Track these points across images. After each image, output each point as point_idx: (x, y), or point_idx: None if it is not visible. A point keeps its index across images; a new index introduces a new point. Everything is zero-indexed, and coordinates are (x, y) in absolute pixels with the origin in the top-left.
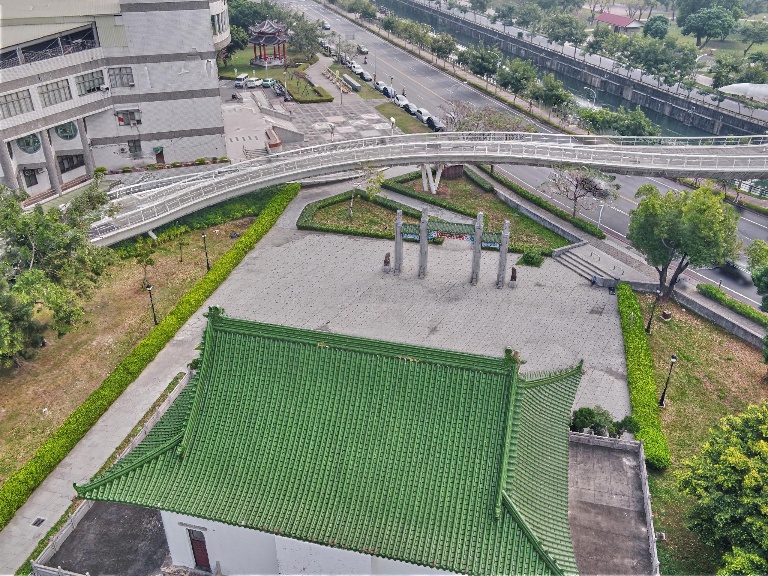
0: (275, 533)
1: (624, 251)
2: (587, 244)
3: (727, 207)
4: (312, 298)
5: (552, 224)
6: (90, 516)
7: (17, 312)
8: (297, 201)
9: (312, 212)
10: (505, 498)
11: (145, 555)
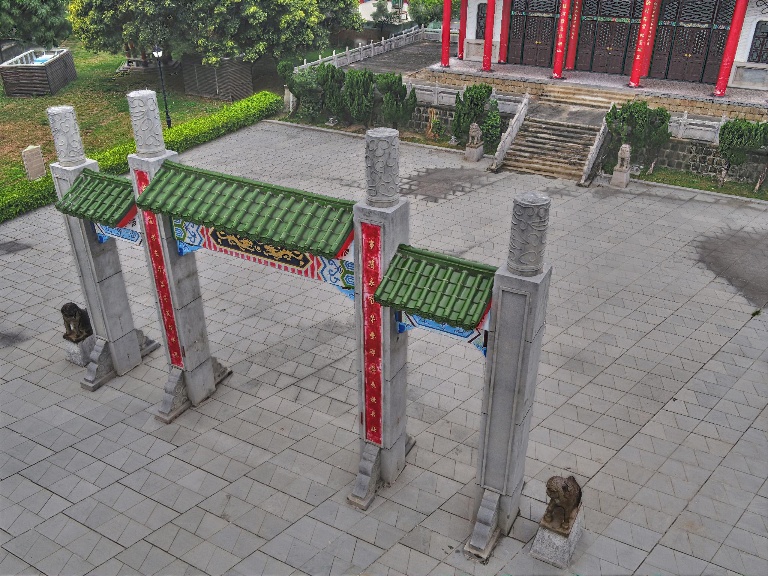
0: None
1: None
2: None
3: None
4: None
5: None
6: None
7: None
8: None
9: None
10: None
11: None
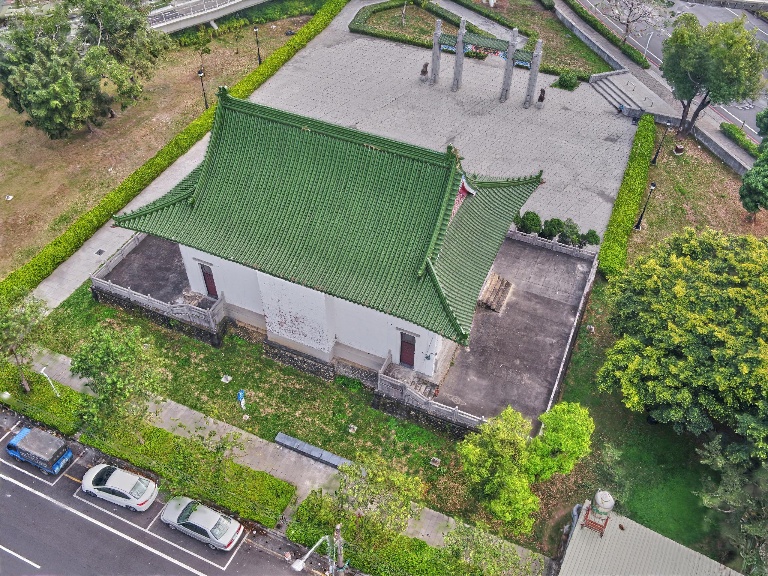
0: (254, 268)
1: (663, 83)
2: (628, 72)
3: (761, 44)
4: (348, 99)
5: (600, 49)
6: (136, 251)
7: (86, 83)
8: (354, 3)
9: (365, 15)
10: (428, 264)
11: (174, 283)
